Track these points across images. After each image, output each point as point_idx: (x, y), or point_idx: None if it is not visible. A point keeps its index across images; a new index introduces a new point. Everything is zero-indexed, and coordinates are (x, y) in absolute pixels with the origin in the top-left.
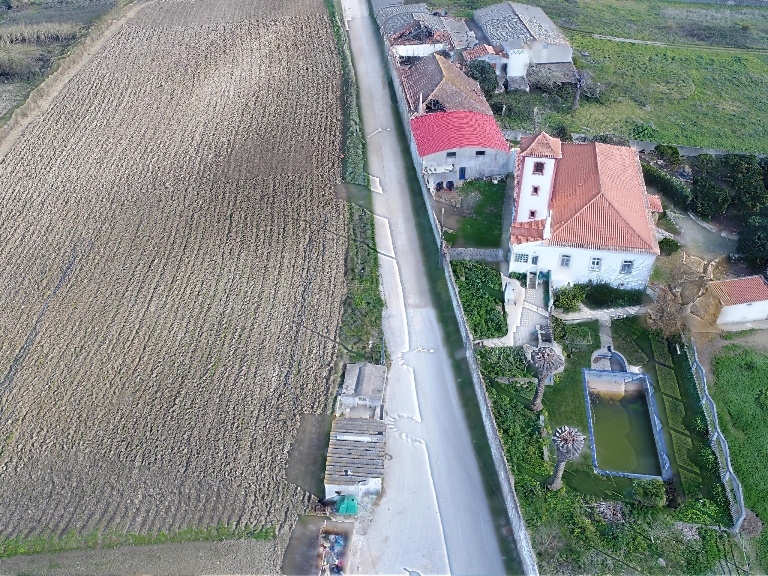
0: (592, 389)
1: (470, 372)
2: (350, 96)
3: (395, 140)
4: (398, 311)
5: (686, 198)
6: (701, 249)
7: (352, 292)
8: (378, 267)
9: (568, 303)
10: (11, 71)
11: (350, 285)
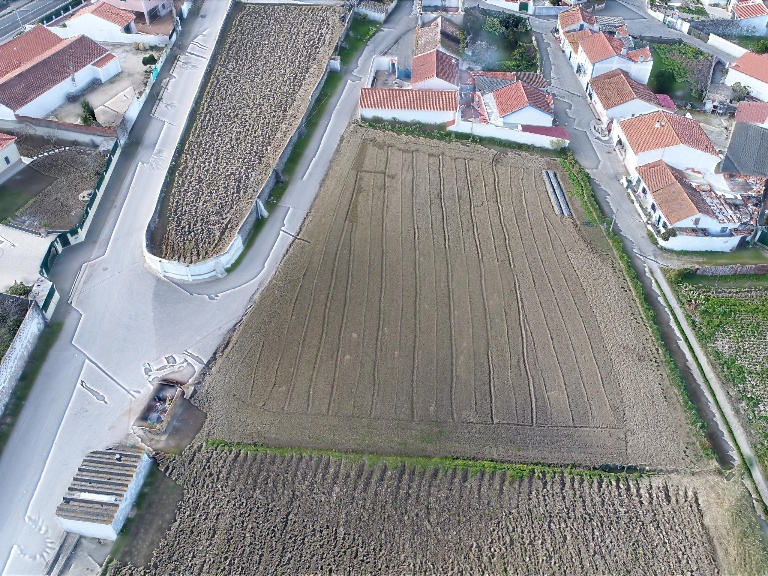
0: None
1: None
2: None
3: None
4: None
5: None
6: None
7: None
8: None
9: None
10: None
11: None
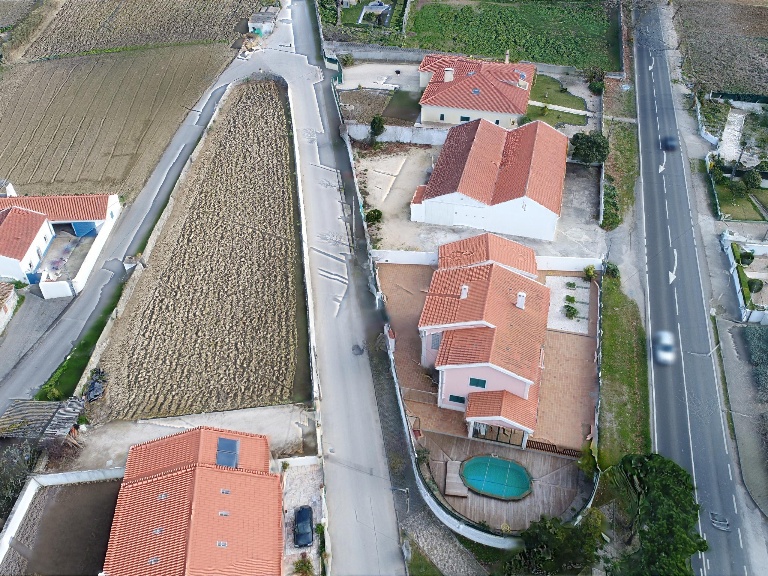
0: None
1: None
2: None
3: None
4: None
5: None
6: None
7: None
8: None
9: None
10: None
11: None
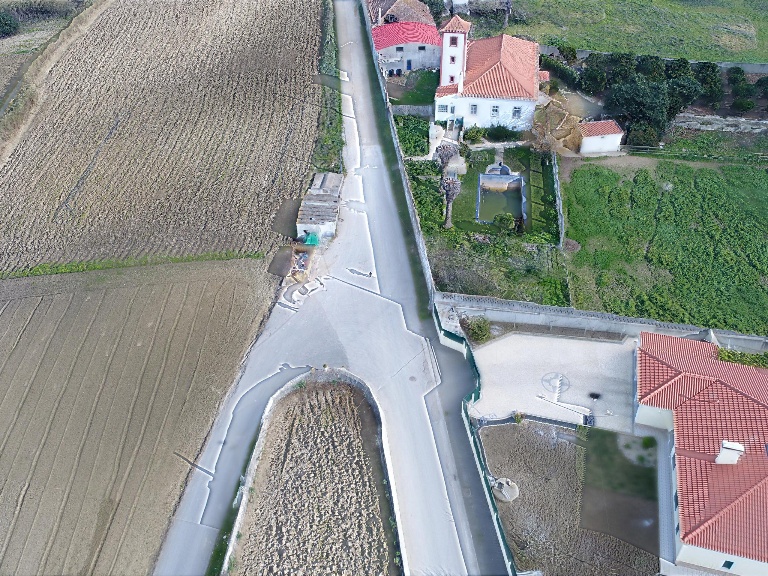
0: (485, 187)
1: (401, 176)
2: (328, 19)
3: (362, 49)
4: (354, 147)
5: (574, 79)
6: (581, 112)
7: (322, 136)
8: (342, 123)
9: (473, 135)
10: (52, 9)
11: (321, 132)
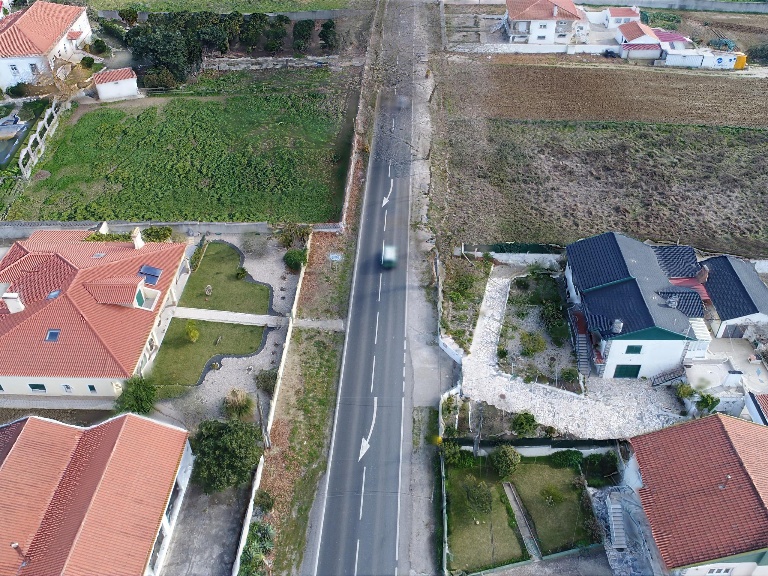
0: None
1: None
2: None
3: None
4: None
5: (122, 37)
6: (121, 65)
7: None
8: None
9: None
10: None
11: None
